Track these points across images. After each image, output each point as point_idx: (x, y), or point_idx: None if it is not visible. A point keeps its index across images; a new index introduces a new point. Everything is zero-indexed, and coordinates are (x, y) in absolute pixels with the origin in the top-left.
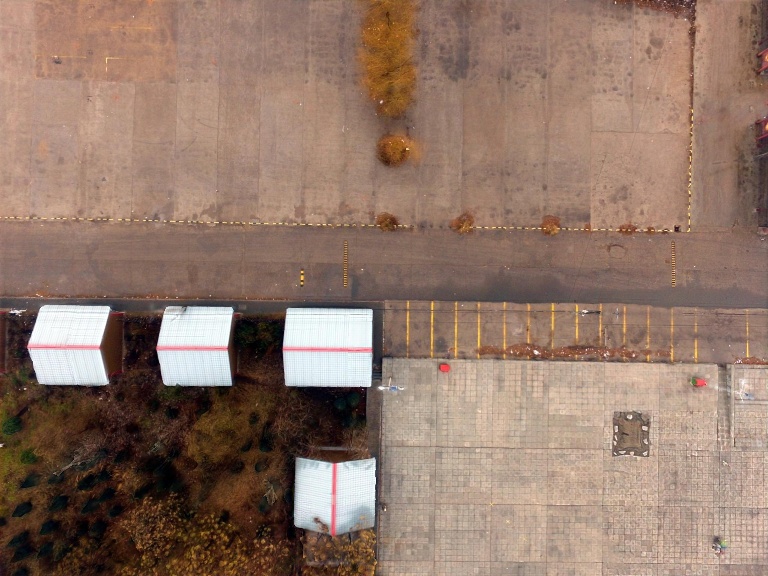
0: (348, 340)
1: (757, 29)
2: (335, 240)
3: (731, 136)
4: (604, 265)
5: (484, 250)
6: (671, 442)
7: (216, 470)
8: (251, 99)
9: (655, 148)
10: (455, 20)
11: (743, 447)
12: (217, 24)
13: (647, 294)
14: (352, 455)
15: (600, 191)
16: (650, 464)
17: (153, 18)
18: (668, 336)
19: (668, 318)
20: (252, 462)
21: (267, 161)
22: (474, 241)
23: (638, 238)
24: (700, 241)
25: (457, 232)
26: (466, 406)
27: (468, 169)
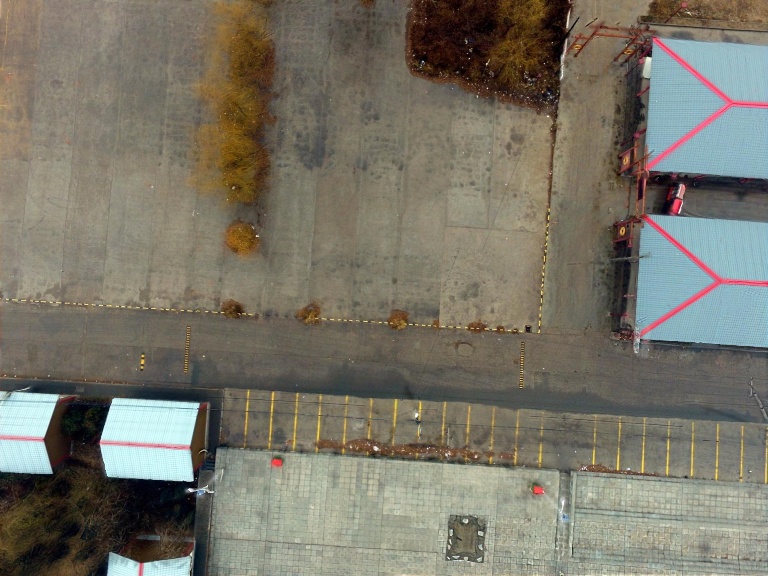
0: (168, 436)
1: (620, 129)
2: (178, 325)
3: (588, 237)
4: (450, 363)
5: (329, 342)
6: (507, 549)
7: (39, 555)
8: (102, 180)
9: (509, 246)
10: (313, 108)
11: (581, 558)
12: (73, 103)
13: (493, 394)
14: (162, 555)
15: (451, 287)
16: (484, 570)
17: (9, 95)
18: (512, 439)
19: (513, 420)
20: (80, 546)
21: (114, 243)
22: (319, 332)
23: (487, 337)
24: (550, 343)
25: (302, 322)
26: (299, 501)
27: (317, 259)
